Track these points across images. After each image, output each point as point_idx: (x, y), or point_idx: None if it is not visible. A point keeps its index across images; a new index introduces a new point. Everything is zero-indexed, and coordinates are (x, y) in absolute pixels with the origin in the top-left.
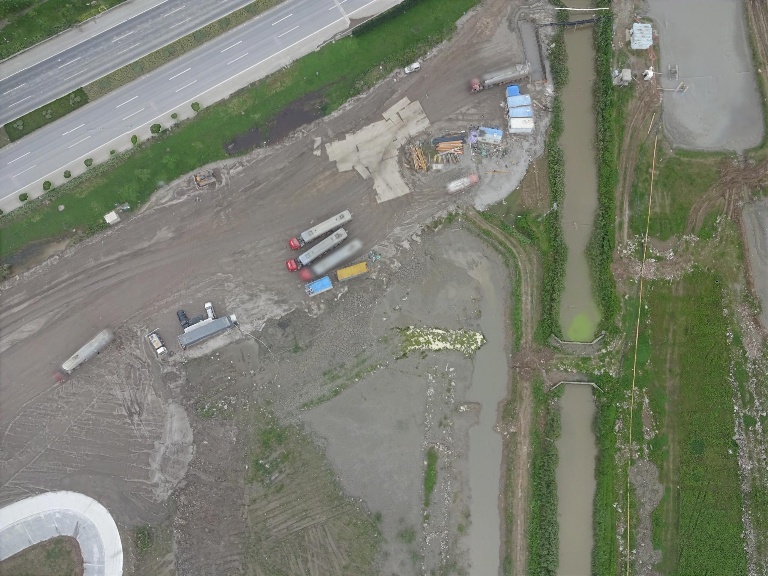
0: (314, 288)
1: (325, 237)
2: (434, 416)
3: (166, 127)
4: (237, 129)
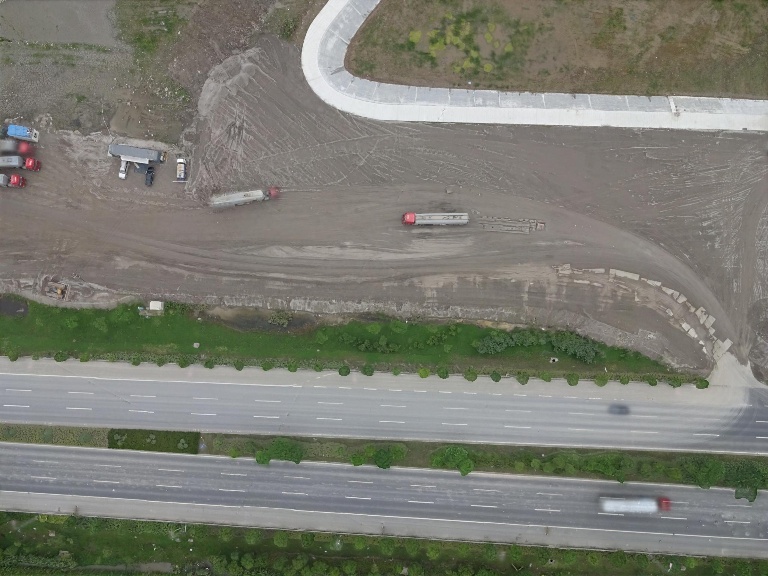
0: (25, 132)
1: None
2: None
3: None
4: (5, 323)
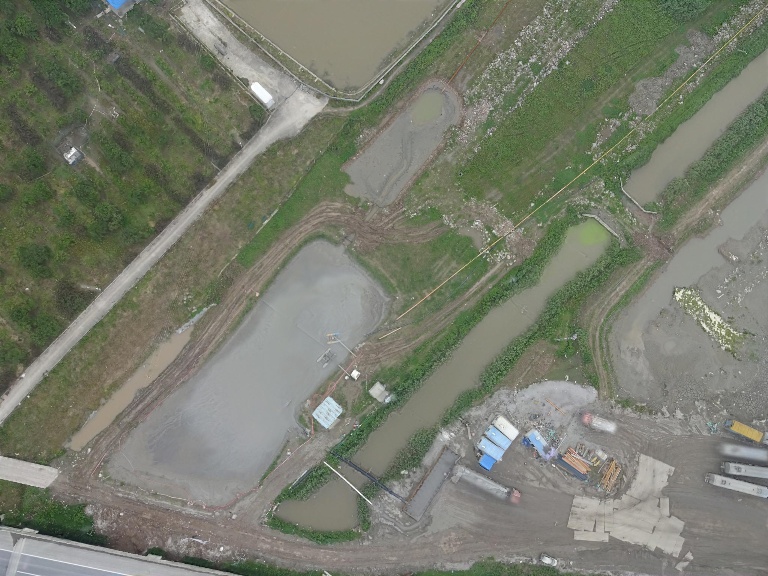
0: None
1: (742, 478)
2: (760, 271)
3: None
4: None
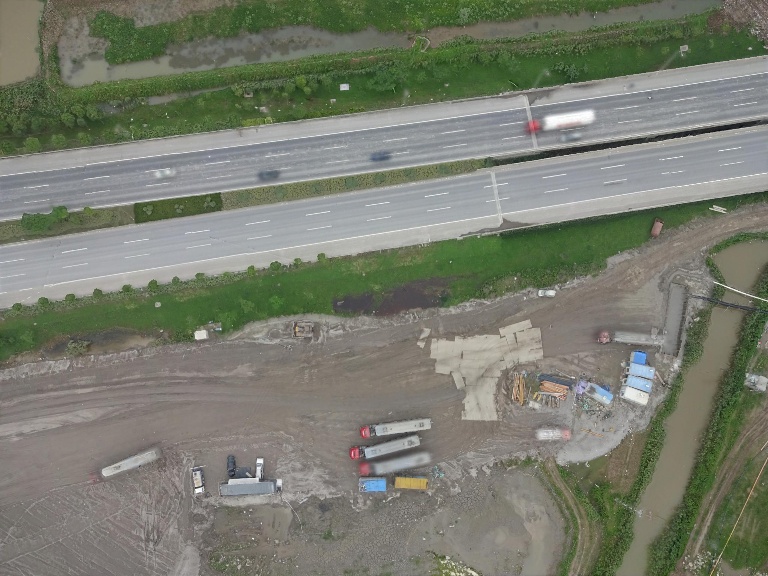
0: (368, 486)
1: (397, 435)
2: None
3: (285, 263)
4: (352, 288)
